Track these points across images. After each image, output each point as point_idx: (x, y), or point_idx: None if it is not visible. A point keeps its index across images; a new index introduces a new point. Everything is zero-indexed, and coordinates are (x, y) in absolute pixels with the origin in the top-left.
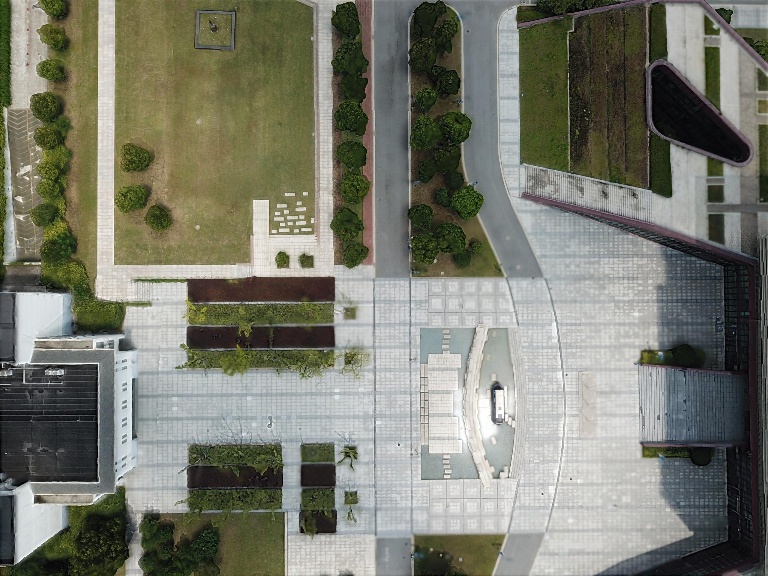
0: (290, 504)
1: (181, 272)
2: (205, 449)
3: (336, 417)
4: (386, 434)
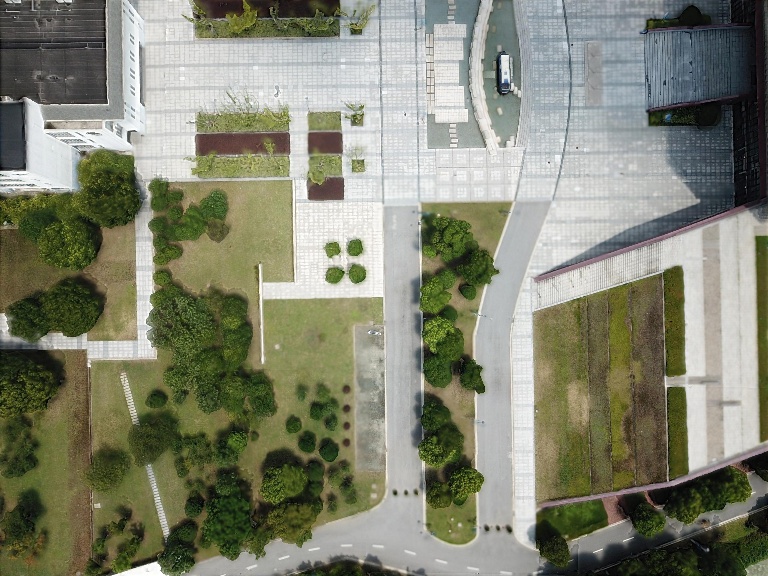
0: (298, 172)
1: None
2: (213, 117)
3: (342, 87)
4: (392, 104)
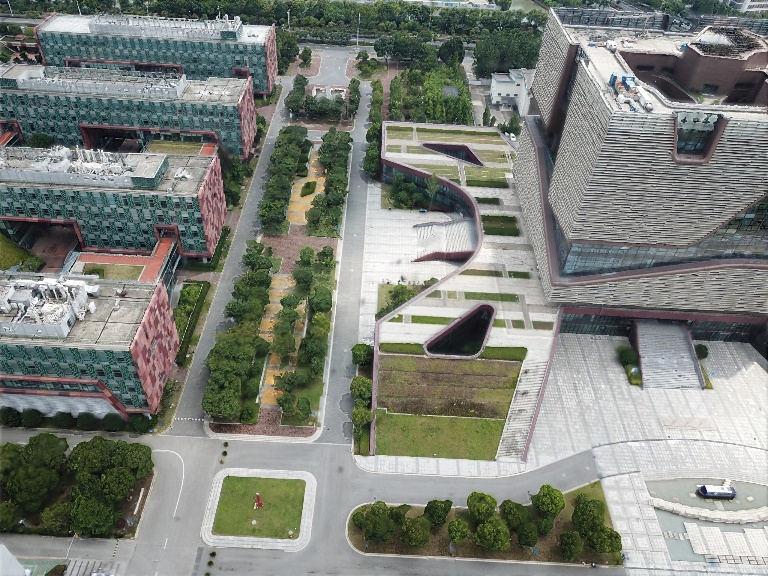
0: None
1: None
2: None
3: None
4: None
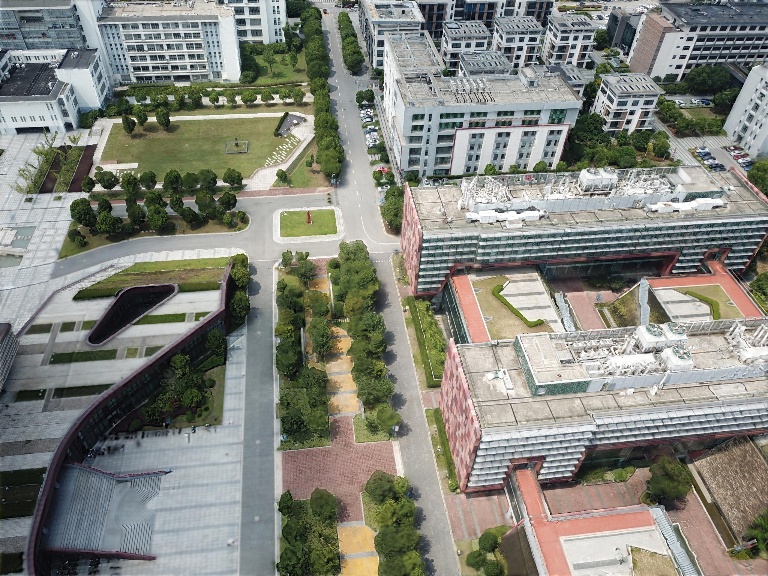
0: None
1: (103, 141)
2: None
3: None
4: None
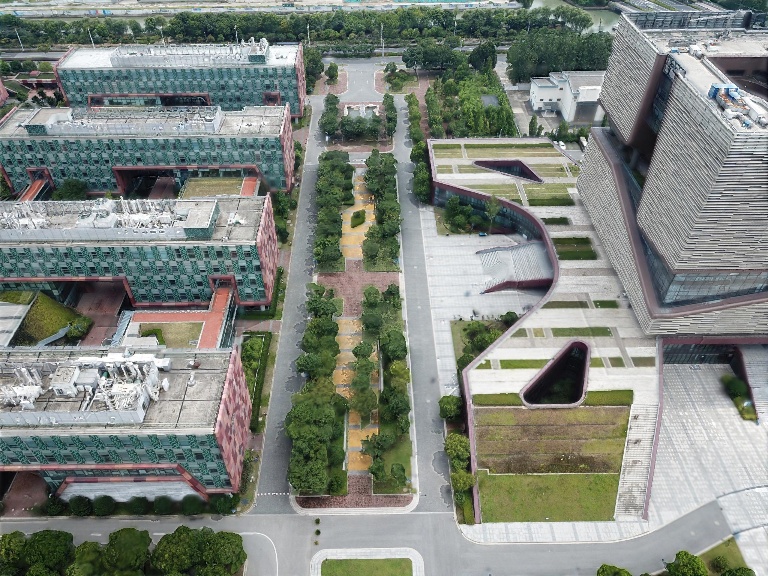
0: None
1: None
2: None
3: None
4: None
